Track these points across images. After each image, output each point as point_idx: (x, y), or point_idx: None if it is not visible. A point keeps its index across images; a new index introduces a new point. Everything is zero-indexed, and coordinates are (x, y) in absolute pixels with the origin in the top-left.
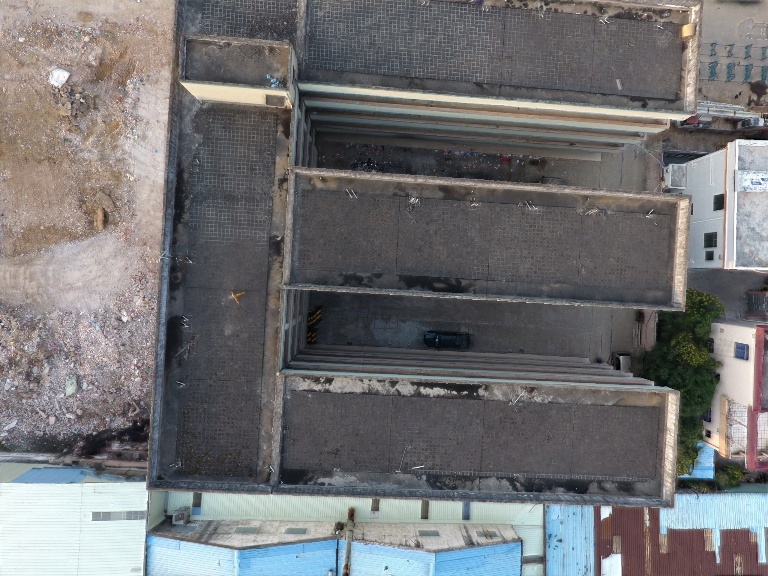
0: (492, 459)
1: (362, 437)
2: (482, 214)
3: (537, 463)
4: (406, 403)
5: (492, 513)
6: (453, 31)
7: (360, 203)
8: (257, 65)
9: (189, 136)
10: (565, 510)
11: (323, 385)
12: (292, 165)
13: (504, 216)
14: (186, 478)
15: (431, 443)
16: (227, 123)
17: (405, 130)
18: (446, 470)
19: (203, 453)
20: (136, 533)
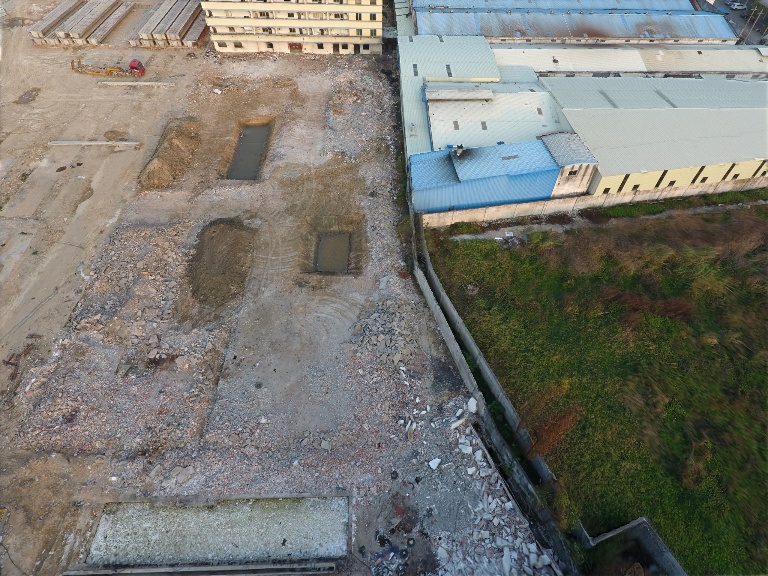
0: None
1: None
2: None
3: None
4: None
5: None
6: None
7: None
8: None
9: None
10: None
11: None
12: None
13: None
14: None
15: None
16: None
17: None
18: None
19: None
20: None
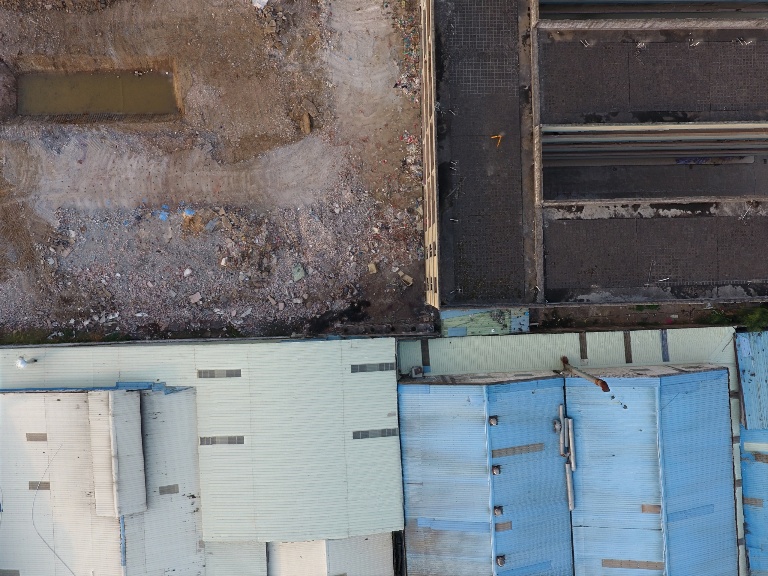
0: (727, 269)
1: (613, 256)
2: (700, 53)
3: (767, 270)
4: (648, 224)
5: (689, 354)
6: None
7: (594, 51)
8: None
9: (443, 5)
10: (755, 348)
11: (575, 214)
12: None
13: (720, 53)
14: (465, 303)
15: (673, 258)
16: None
17: (588, 9)
18: (688, 281)
19: (478, 280)
20: (389, 382)
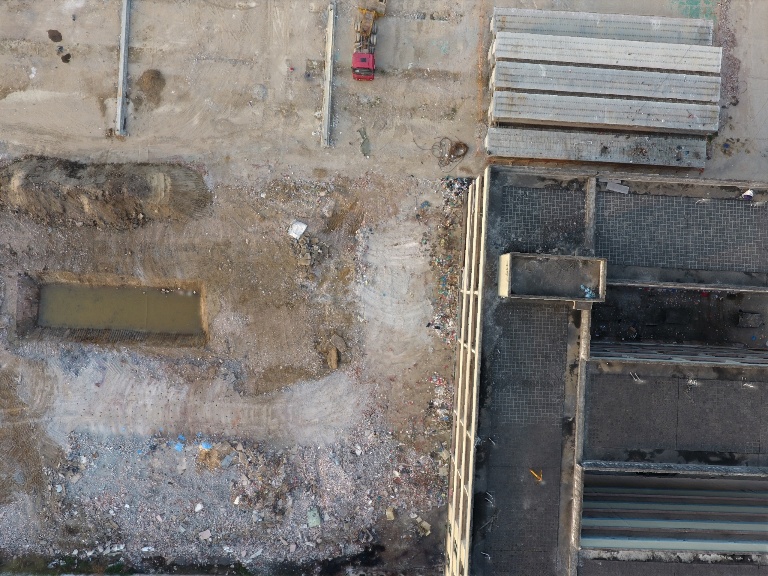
0: None
1: None
2: (753, 393)
3: None
4: (687, 569)
5: None
6: (724, 226)
7: (643, 385)
8: (572, 277)
9: (490, 328)
10: None
11: (612, 553)
12: (589, 357)
13: None
14: None
15: None
16: (524, 316)
17: None
18: None
19: None
20: None
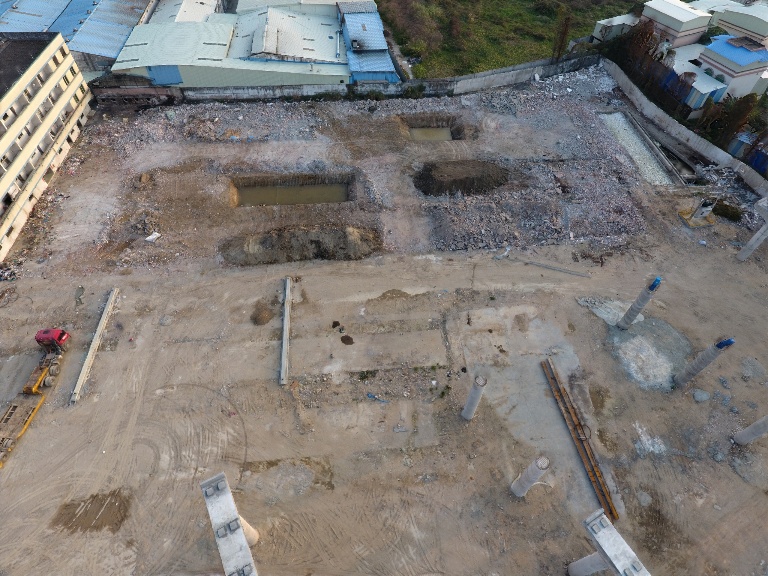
0: None
1: None
2: None
3: None
4: None
5: None
6: None
7: None
8: None
9: None
10: None
11: None
12: None
13: None
14: None
15: None
16: None
17: None
18: None
19: None
20: None
